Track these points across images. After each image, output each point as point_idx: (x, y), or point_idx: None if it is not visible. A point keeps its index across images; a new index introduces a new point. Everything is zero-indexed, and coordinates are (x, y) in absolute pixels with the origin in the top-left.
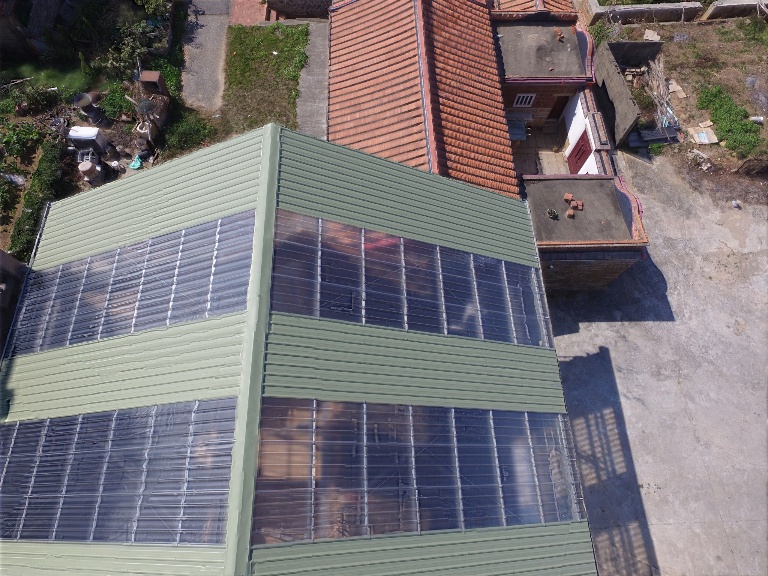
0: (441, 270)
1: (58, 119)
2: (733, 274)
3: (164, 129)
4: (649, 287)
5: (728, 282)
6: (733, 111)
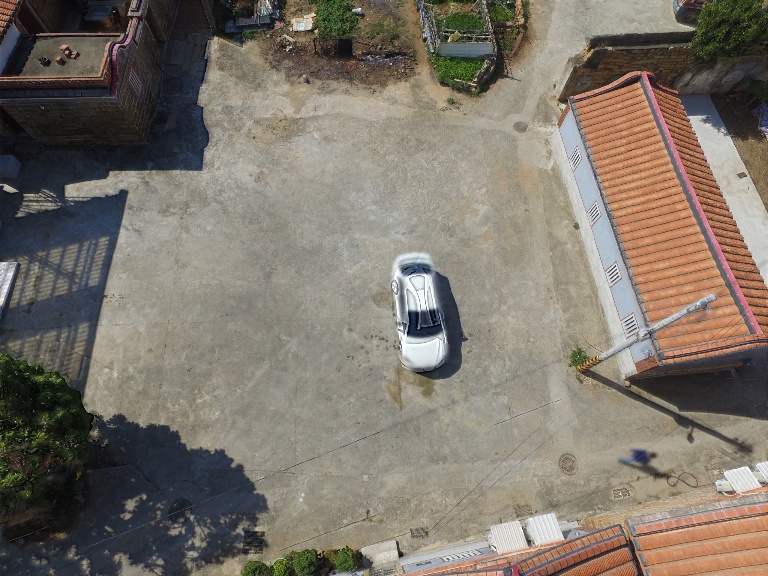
0: None
1: None
2: (278, 135)
3: None
4: (190, 144)
5: (269, 141)
6: (336, 4)
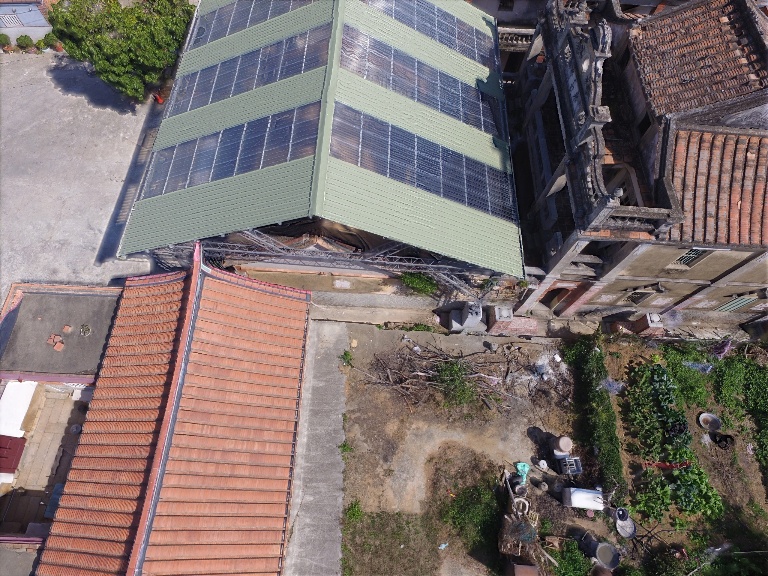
0: (212, 167)
1: (624, 521)
2: None
3: (499, 511)
4: None
5: None
6: None
